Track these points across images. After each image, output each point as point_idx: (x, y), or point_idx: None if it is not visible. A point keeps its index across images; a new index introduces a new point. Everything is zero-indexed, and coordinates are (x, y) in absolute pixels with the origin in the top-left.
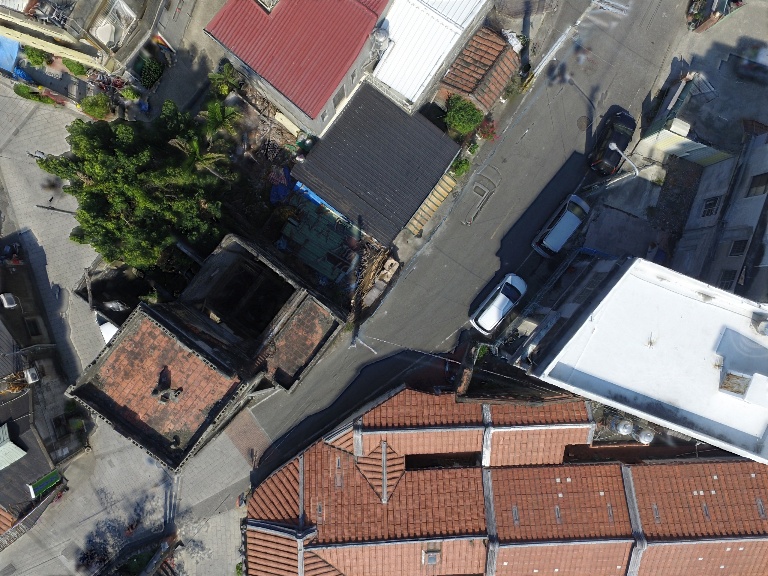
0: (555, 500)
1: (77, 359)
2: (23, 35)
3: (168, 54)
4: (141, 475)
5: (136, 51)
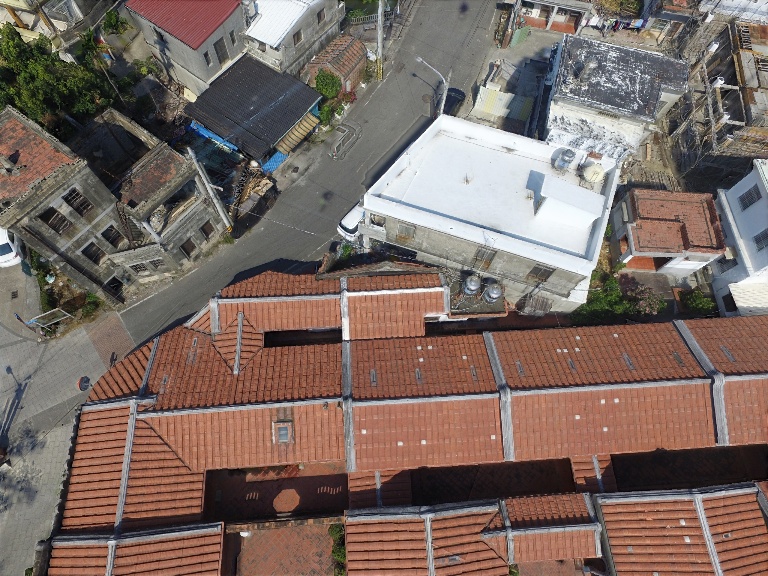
0: (416, 364)
1: None
2: None
3: (109, 61)
4: None
5: (79, 39)
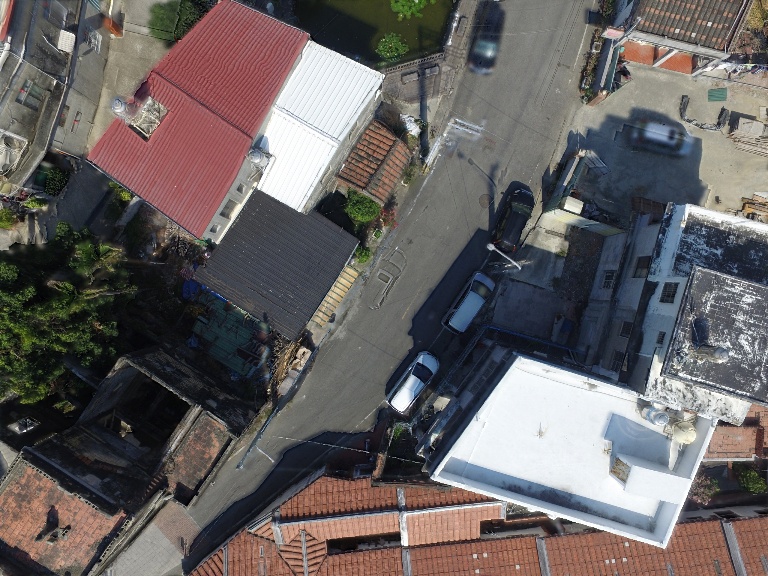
0: None
1: (4, 462)
2: None
3: (73, 161)
4: None
5: (32, 171)
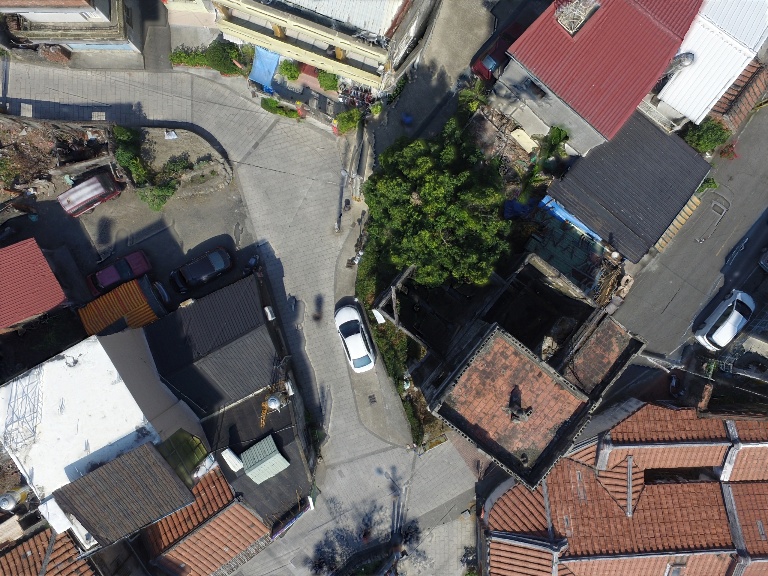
0: None
1: (311, 370)
2: (308, 53)
3: (408, 70)
4: (370, 485)
5: None
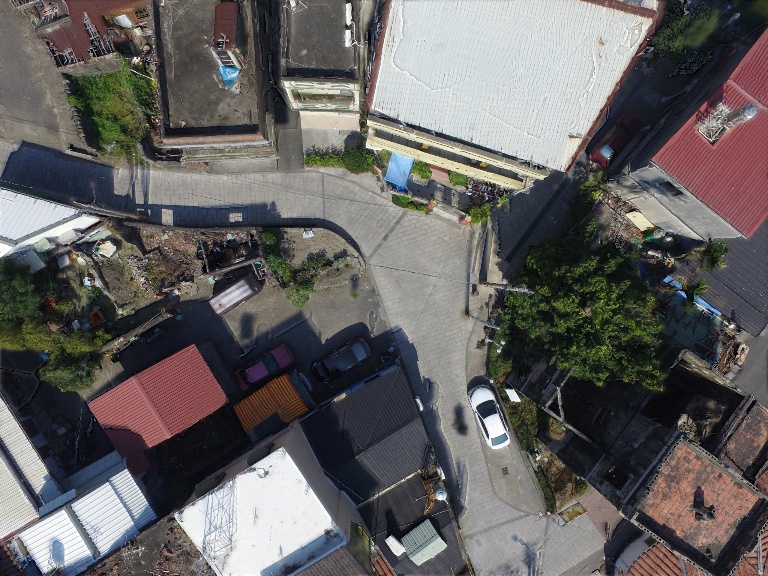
0: None
1: (447, 447)
2: (455, 163)
3: None
4: (506, 552)
5: None
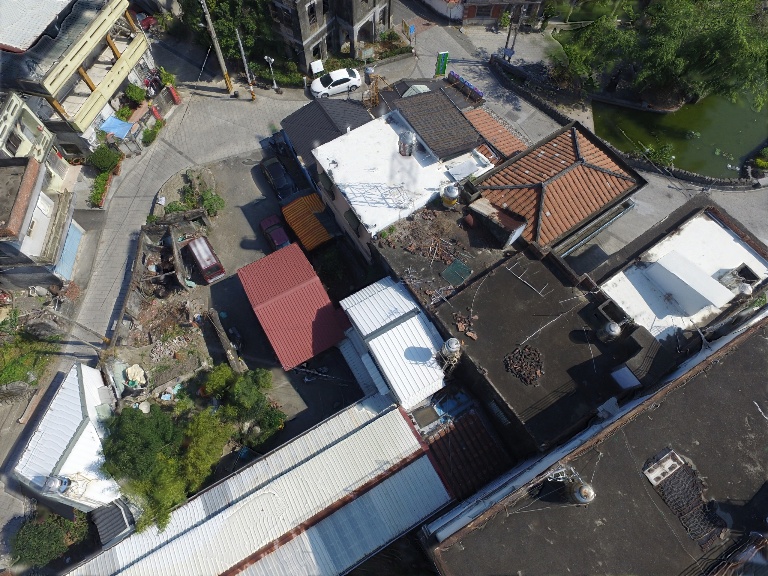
0: None
1: None
2: (112, 70)
3: None
4: None
5: None
